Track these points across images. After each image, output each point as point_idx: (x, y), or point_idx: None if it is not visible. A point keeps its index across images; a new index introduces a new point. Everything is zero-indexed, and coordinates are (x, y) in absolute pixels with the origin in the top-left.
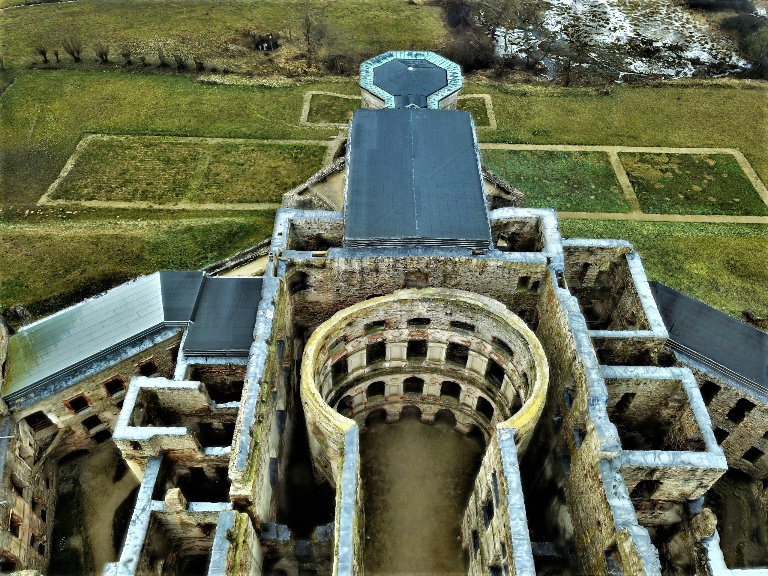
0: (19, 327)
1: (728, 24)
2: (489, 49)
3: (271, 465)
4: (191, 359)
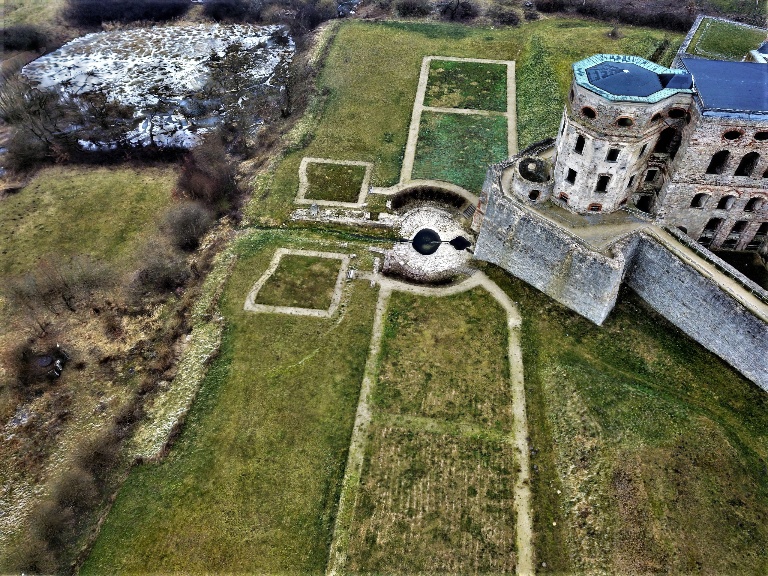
0: None
1: (221, 12)
2: (182, 148)
3: None
4: None
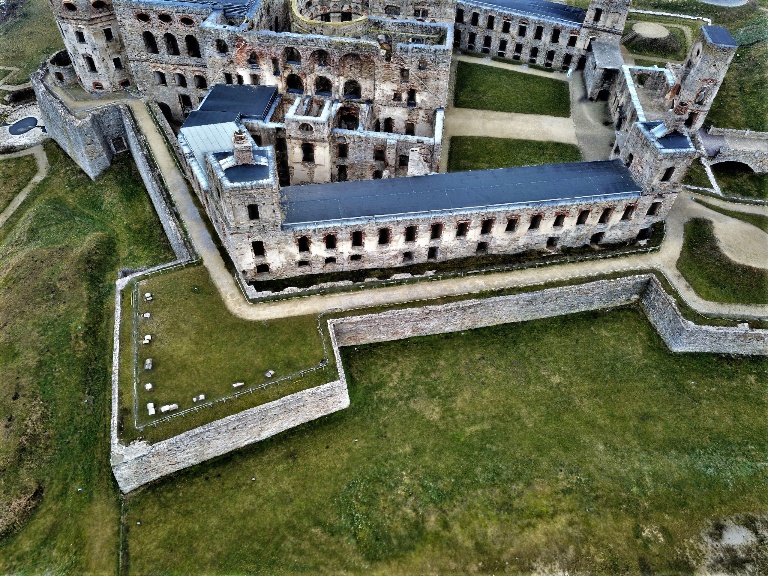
0: (111, 319)
1: None
2: None
3: (348, 95)
4: (266, 120)
